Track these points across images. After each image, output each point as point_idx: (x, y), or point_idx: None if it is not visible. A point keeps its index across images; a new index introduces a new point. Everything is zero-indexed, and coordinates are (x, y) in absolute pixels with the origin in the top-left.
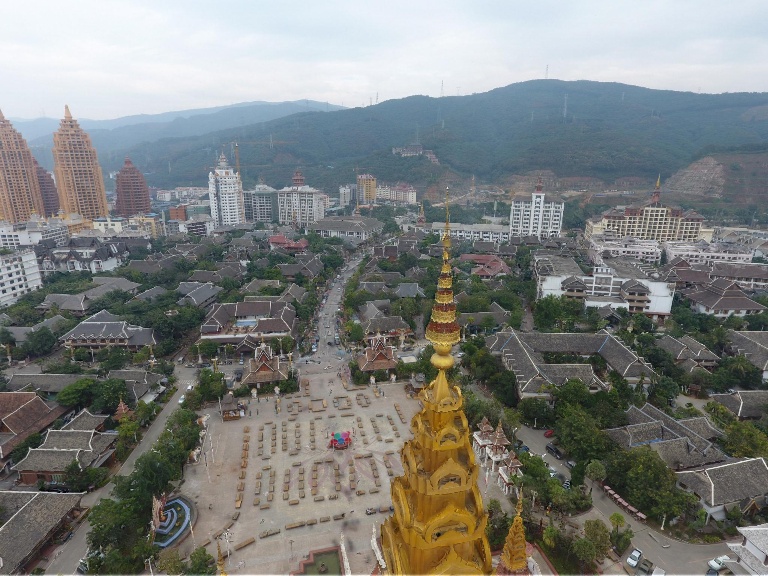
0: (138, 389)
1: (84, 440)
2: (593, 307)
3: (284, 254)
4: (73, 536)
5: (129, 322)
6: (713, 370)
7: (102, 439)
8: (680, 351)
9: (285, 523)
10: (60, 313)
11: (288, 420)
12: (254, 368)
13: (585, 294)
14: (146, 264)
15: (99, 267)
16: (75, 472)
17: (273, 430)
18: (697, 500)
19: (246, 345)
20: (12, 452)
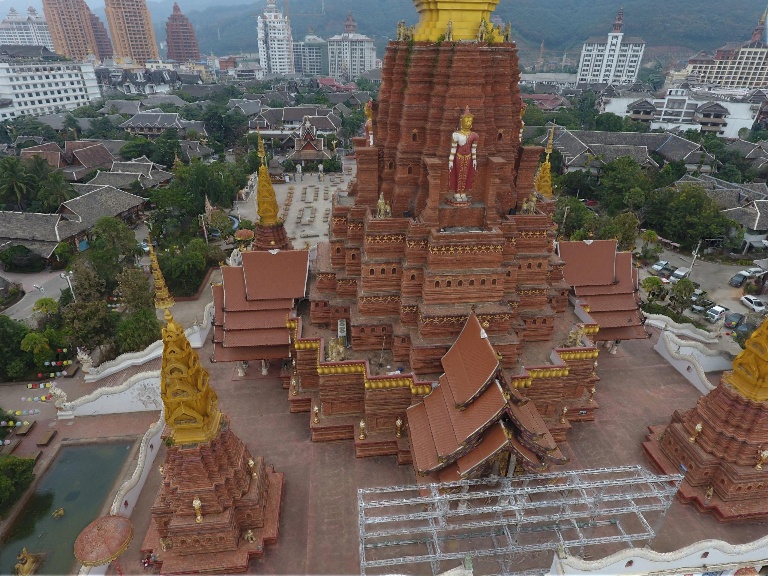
0: (191, 153)
1: (144, 170)
2: None
3: (333, 92)
4: (139, 228)
5: (182, 117)
6: None
7: (160, 174)
8: (751, 150)
9: (324, 232)
10: (119, 114)
11: (330, 185)
12: (299, 146)
13: (652, 116)
14: (197, 88)
15: (153, 92)
16: (138, 189)
17: (316, 189)
18: (738, 225)
19: (292, 139)
20: (84, 177)
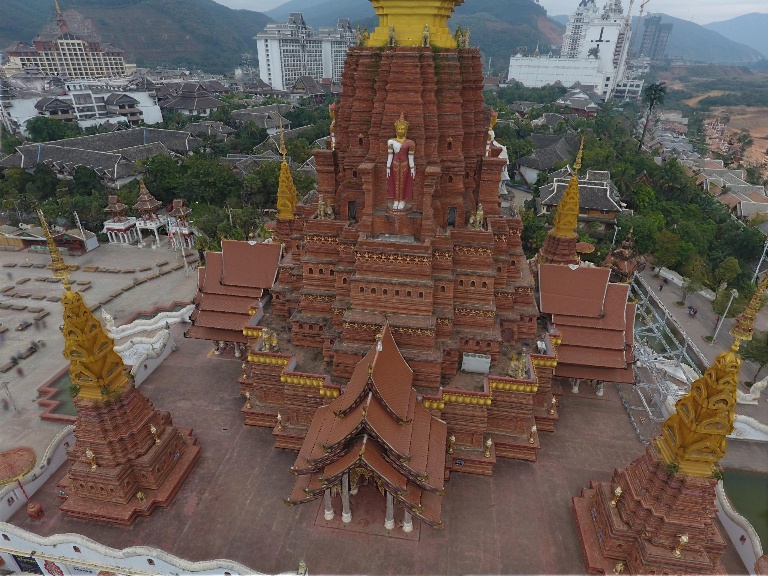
0: None
1: None
2: (91, 127)
3: None
4: None
5: None
6: (238, 138)
7: None
8: (208, 130)
9: None
10: None
11: None
12: None
13: (73, 115)
14: None
15: None
16: None
17: None
18: None
19: None
20: None
